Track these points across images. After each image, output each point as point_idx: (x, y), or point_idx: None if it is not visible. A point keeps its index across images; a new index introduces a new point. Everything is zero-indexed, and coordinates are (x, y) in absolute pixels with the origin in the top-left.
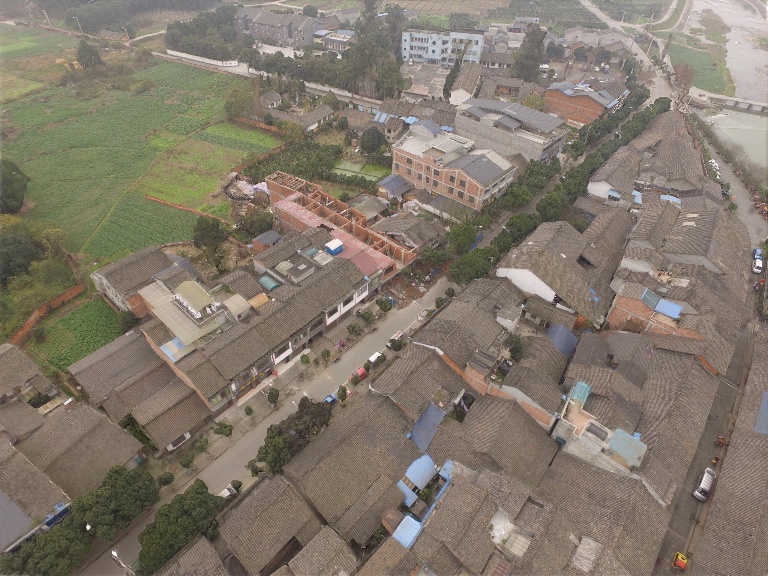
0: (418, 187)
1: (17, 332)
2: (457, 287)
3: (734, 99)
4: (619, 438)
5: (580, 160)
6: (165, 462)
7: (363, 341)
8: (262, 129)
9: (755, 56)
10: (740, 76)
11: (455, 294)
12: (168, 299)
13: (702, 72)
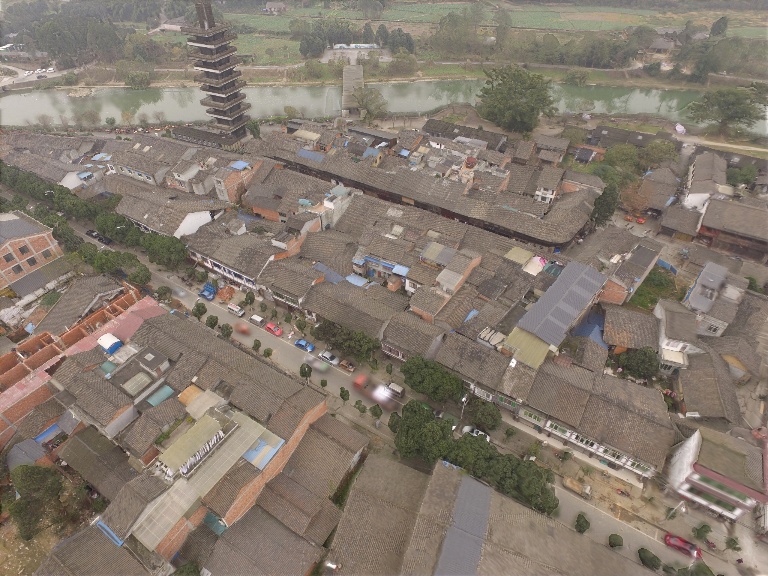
0: None
1: None
2: (170, 279)
3: None
4: (336, 192)
5: None
6: (372, 452)
7: (232, 335)
8: None
9: None
10: None
11: (194, 266)
12: (182, 488)
13: None
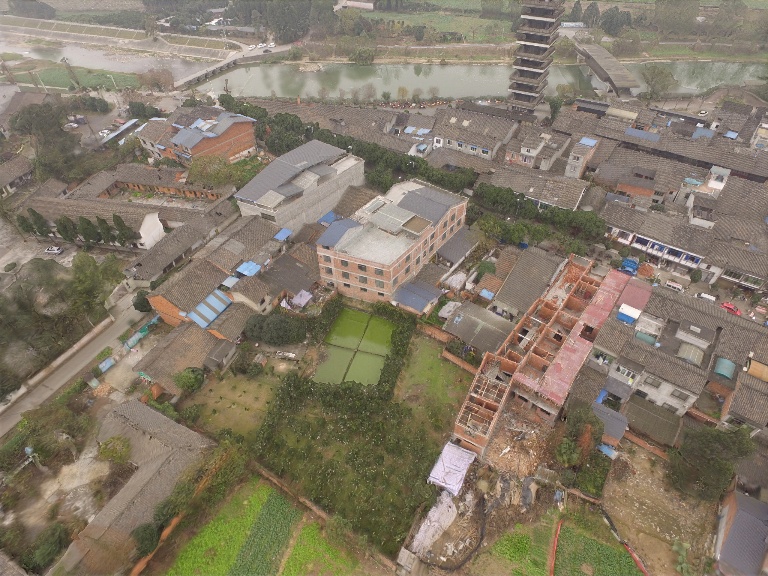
0: (417, 273)
1: None
2: None
3: (186, 80)
4: (718, 172)
5: None
6: None
7: None
8: (151, 569)
9: (76, 53)
10: (123, 69)
11: None
12: None
13: (104, 80)
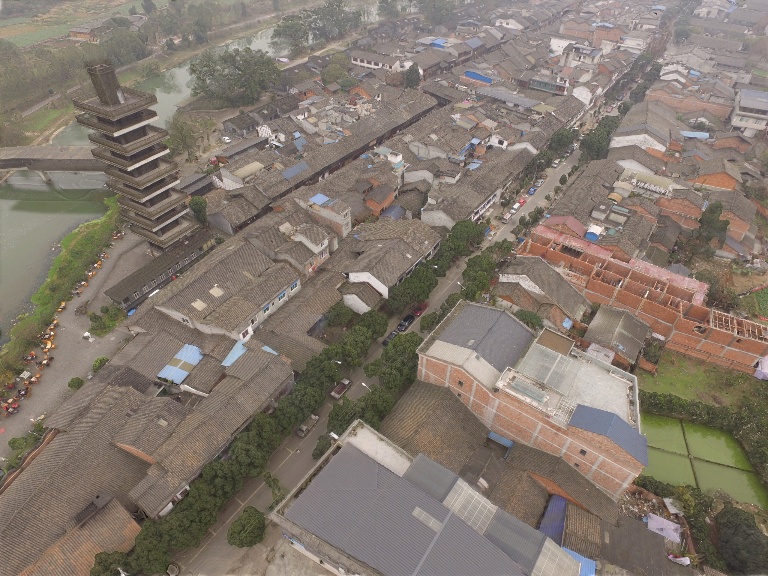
0: None
1: (760, 203)
2: None
3: None
4: None
5: (229, 566)
6: None
7: None
8: None
9: None
10: None
11: None
12: None
13: None
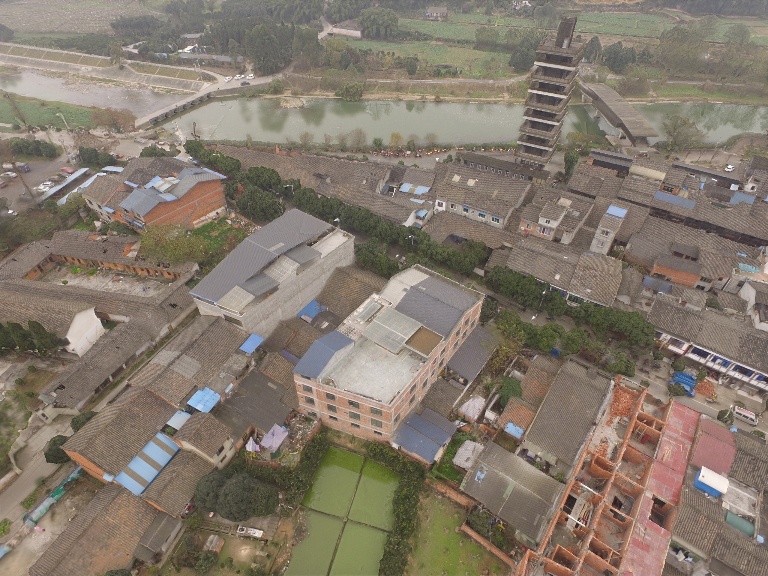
0: (423, 396)
1: None
2: None
3: (152, 117)
4: None
5: None
6: None
7: None
8: None
9: (32, 81)
10: (82, 101)
11: None
12: None
13: None
